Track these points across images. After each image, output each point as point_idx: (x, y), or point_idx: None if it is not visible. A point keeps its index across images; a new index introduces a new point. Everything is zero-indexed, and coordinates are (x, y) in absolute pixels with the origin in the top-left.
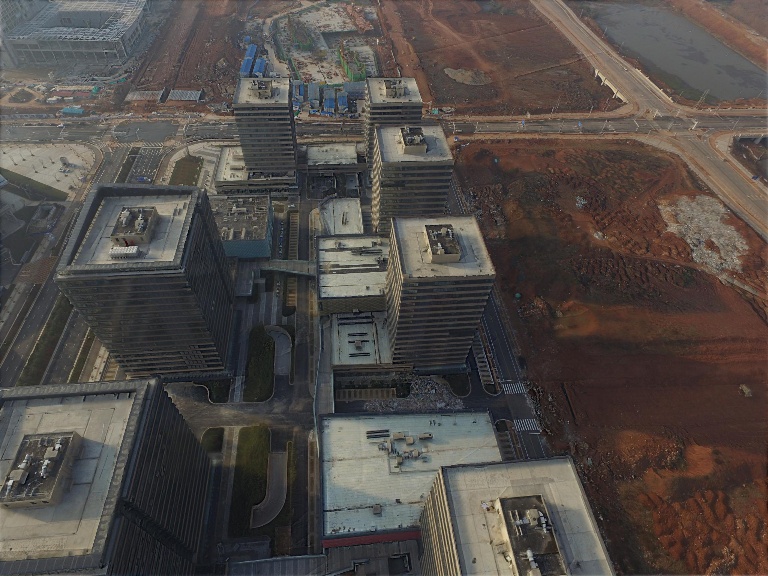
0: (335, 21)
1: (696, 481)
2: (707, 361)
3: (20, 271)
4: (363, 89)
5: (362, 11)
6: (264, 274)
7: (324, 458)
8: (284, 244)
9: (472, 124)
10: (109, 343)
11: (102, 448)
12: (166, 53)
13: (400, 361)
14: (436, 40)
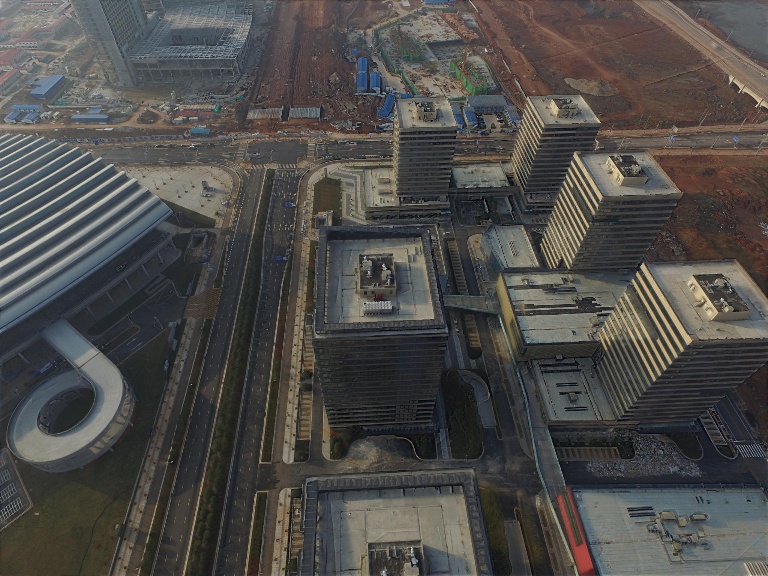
0: (437, 30)
1: None
2: None
3: (187, 304)
4: (490, 103)
5: (461, 19)
6: None
7: (589, 540)
8: (450, 276)
9: (612, 139)
10: (330, 398)
11: (448, 559)
12: (276, 68)
13: (627, 418)
14: (547, 48)
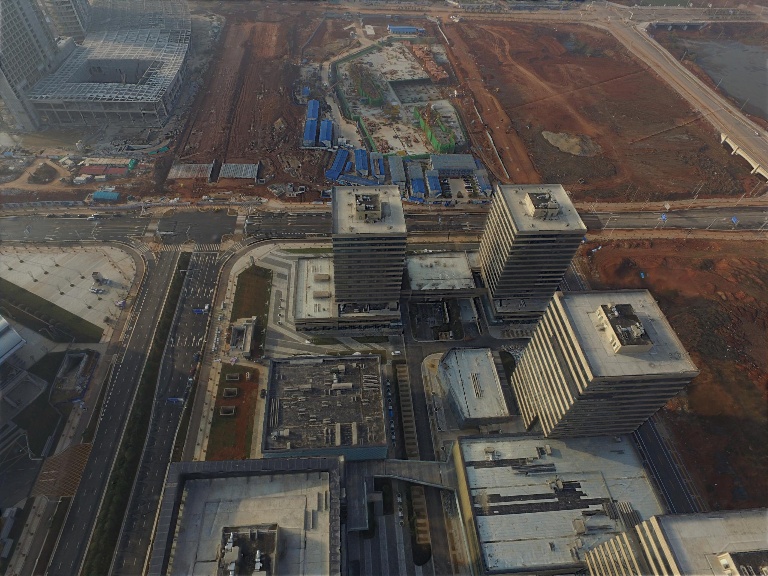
0: (402, 65)
1: None
2: None
3: (40, 472)
4: (457, 166)
5: (430, 52)
6: (377, 480)
7: None
8: (396, 422)
9: (596, 215)
10: None
11: None
12: (212, 109)
13: None
14: (523, 91)
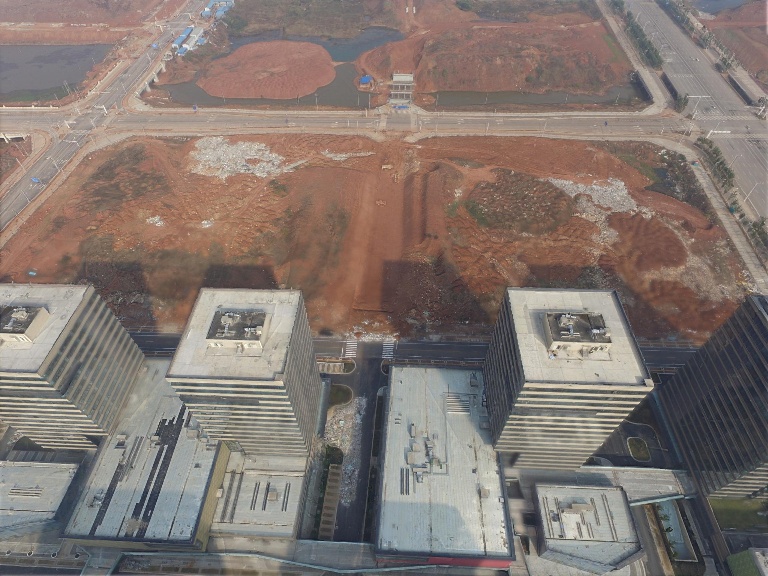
0: None
1: (447, 255)
2: (358, 210)
3: None
4: None
5: None
6: None
7: (428, 551)
8: None
9: None
10: None
11: None
12: None
13: (310, 446)
14: None
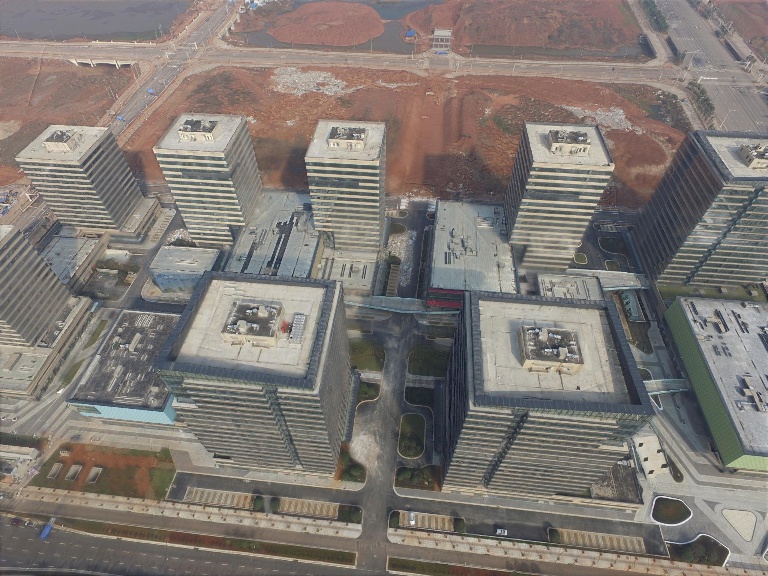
0: None
1: (478, 149)
2: (408, 119)
3: None
4: None
5: None
6: None
7: None
8: None
9: None
10: None
11: (527, 319)
12: None
13: None
14: None
